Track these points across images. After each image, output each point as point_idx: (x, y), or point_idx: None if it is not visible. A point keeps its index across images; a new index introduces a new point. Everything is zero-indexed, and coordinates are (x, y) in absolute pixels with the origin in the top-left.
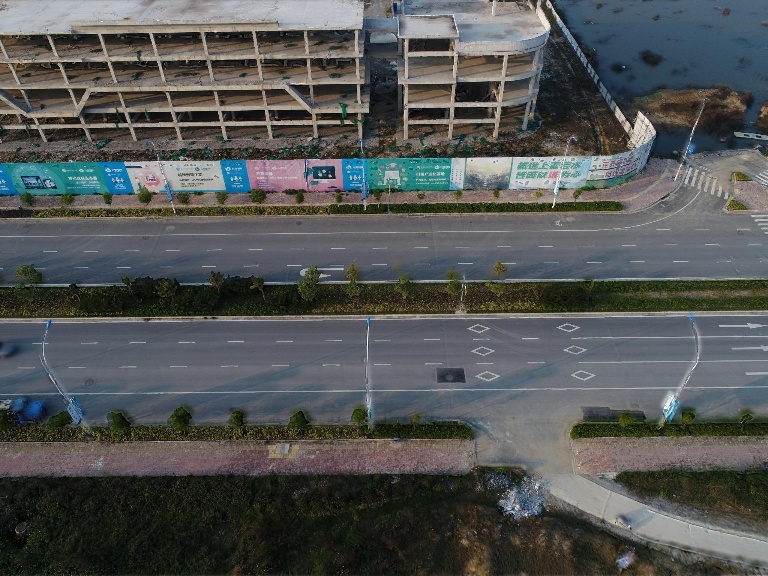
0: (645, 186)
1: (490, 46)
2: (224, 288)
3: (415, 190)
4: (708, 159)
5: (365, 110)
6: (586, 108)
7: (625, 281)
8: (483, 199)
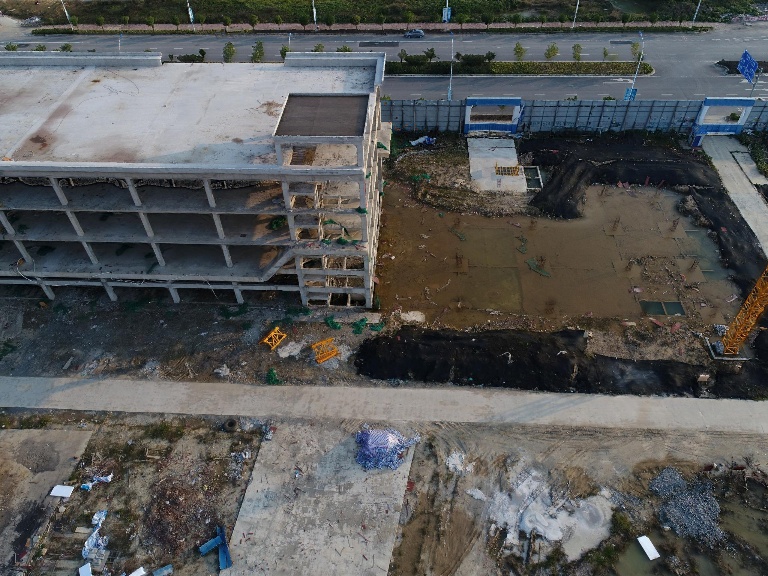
0: None
1: None
2: None
3: None
4: None
5: None
6: None
7: None
8: None
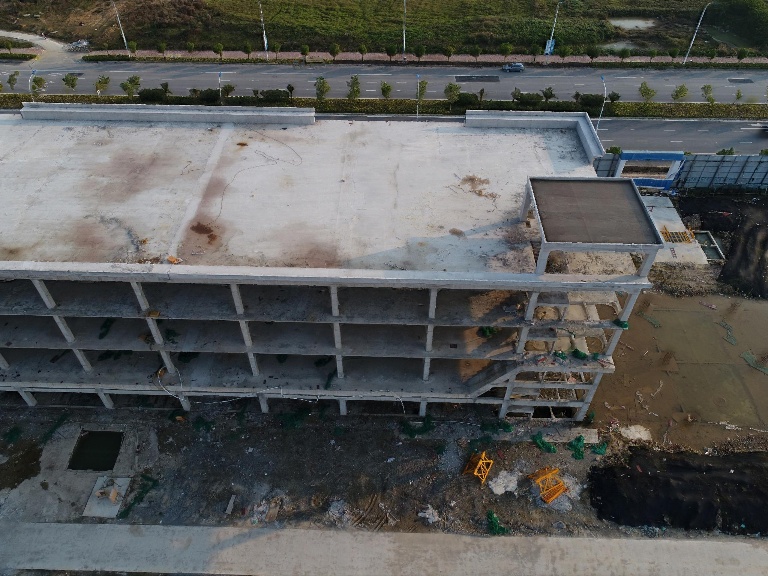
0: None
1: None
2: (192, 98)
3: None
4: None
5: None
6: None
7: None
8: None
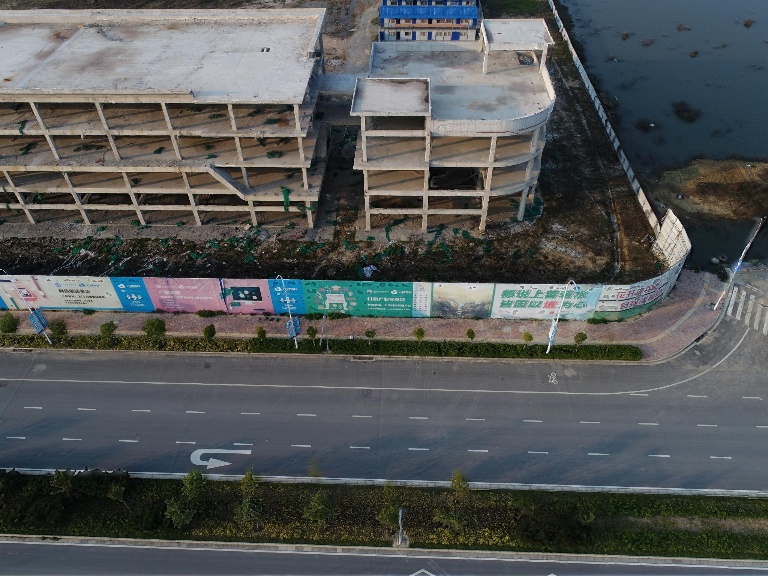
0: (674, 318)
1: (473, 126)
2: (75, 490)
3: (367, 316)
4: (759, 274)
5: (313, 198)
6: (601, 187)
7: (641, 494)
8: (455, 334)
